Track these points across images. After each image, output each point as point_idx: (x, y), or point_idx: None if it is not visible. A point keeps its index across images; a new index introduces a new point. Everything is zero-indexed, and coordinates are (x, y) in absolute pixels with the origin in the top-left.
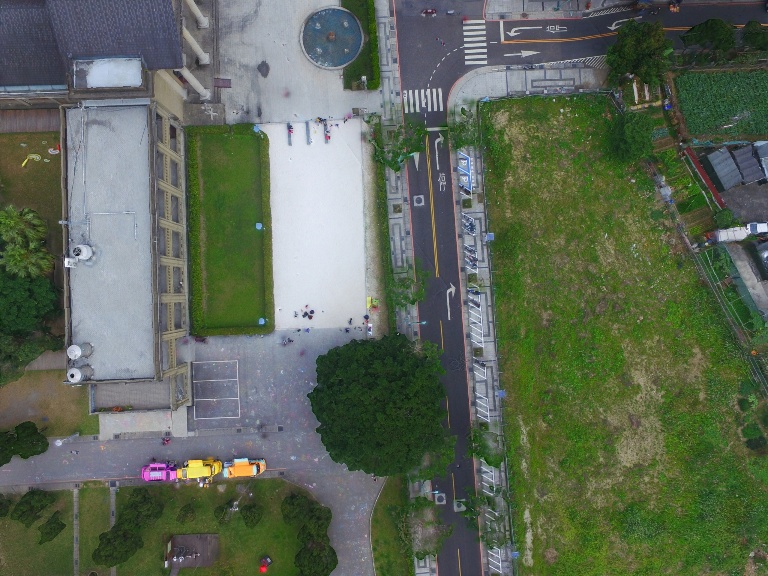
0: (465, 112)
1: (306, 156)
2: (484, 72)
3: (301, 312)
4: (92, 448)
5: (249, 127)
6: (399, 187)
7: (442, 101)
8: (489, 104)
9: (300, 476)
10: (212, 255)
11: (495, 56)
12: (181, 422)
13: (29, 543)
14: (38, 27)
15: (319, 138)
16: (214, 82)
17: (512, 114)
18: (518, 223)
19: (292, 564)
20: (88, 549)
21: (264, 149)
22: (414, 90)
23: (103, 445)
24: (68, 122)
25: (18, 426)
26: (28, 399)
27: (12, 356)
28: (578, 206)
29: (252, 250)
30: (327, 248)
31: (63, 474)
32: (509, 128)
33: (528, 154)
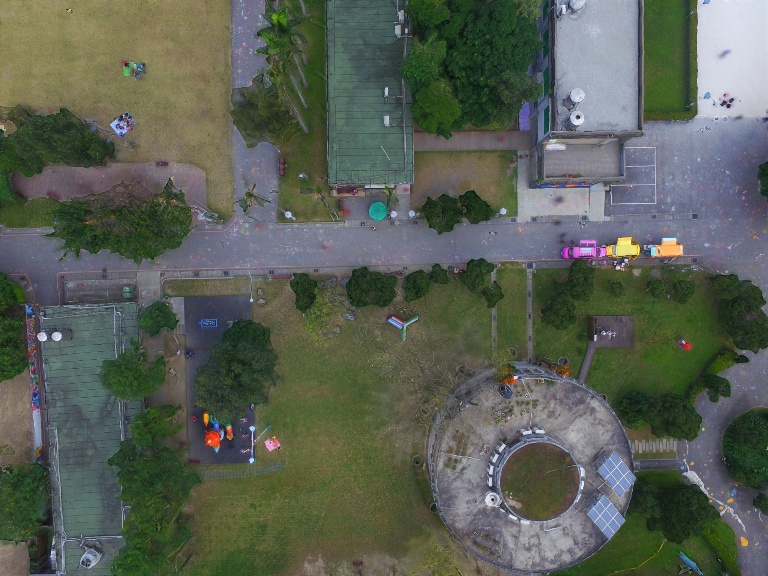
0: None
1: None
2: None
3: (719, 101)
4: (510, 230)
5: None
6: None
7: None
8: None
9: (713, 263)
10: None
11: None
12: (598, 206)
13: (449, 320)
14: None
15: None
16: None
17: None
18: None
19: (704, 348)
20: (506, 327)
21: None
22: None
23: (521, 227)
24: None
25: (467, 192)
26: (449, 180)
27: None
28: None
29: (673, 37)
30: (746, 37)
31: (482, 254)
32: None
33: None
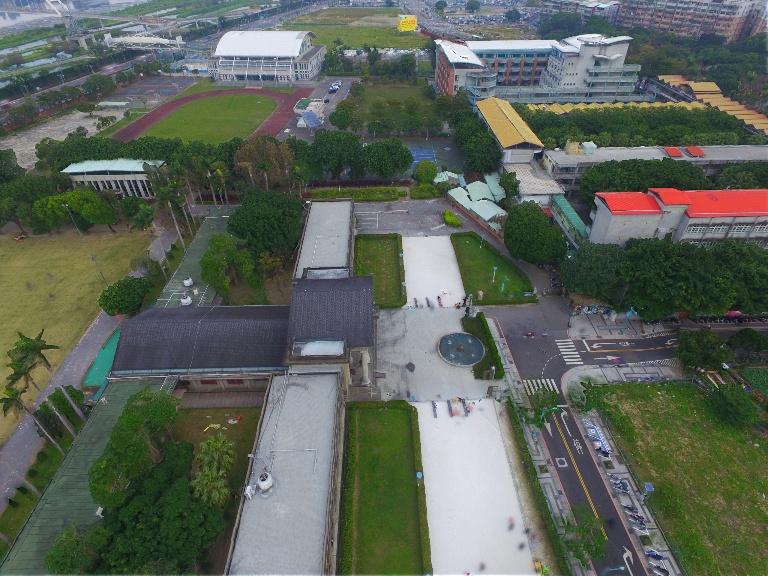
0: (585, 384)
1: (450, 426)
2: (583, 369)
3: None
4: None
5: (402, 402)
6: (540, 450)
7: (556, 387)
8: (596, 388)
9: None
10: (364, 514)
11: (588, 359)
12: None
13: None
14: (265, 331)
15: (460, 413)
16: (373, 374)
17: (619, 395)
18: (667, 482)
19: None
20: None
21: (415, 418)
22: (531, 380)
23: None
24: (272, 384)
25: None
26: None
27: None
28: (718, 467)
29: (405, 509)
30: (481, 508)
31: None
32: (621, 405)
33: (647, 423)
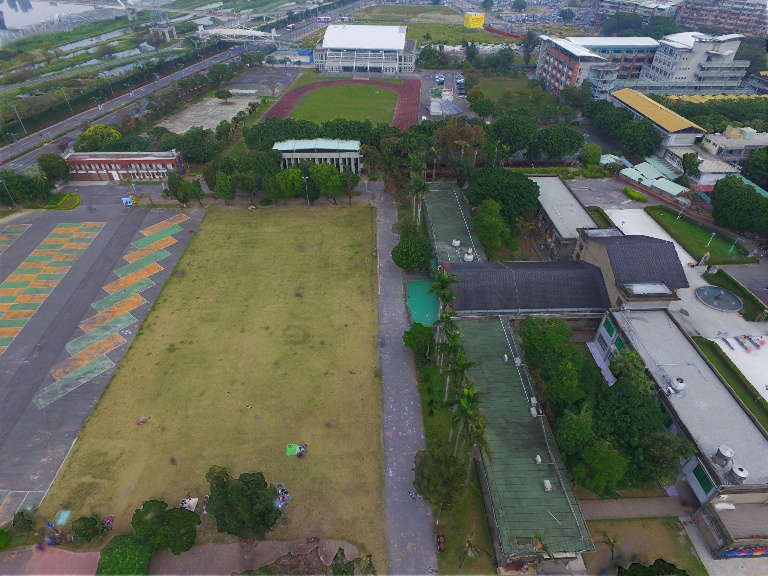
0: None
1: (749, 356)
2: None
3: None
4: None
5: (701, 338)
6: None
7: None
8: None
9: None
10: None
11: None
12: None
13: None
14: (572, 279)
15: (750, 346)
16: None
17: None
18: None
19: None
20: None
21: (720, 350)
22: None
23: None
24: None
25: (658, 560)
26: (621, 551)
27: (667, 457)
28: None
29: (756, 415)
30: None
31: None
32: None
33: None
